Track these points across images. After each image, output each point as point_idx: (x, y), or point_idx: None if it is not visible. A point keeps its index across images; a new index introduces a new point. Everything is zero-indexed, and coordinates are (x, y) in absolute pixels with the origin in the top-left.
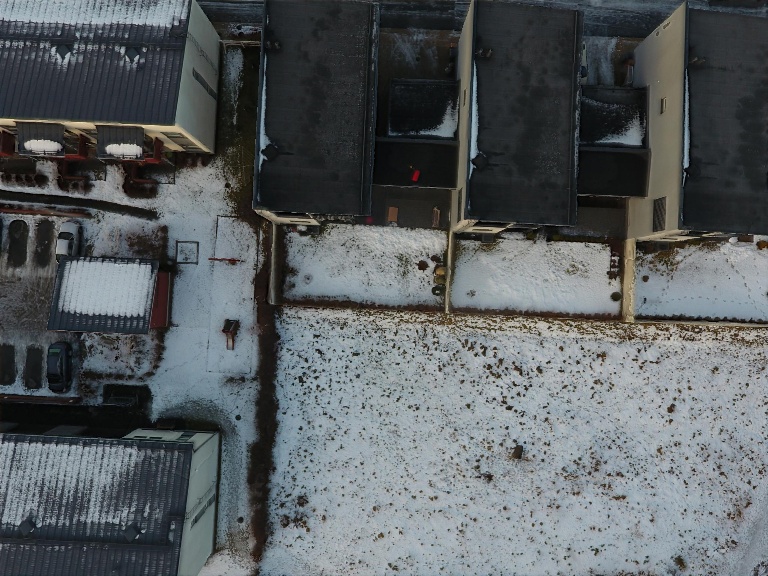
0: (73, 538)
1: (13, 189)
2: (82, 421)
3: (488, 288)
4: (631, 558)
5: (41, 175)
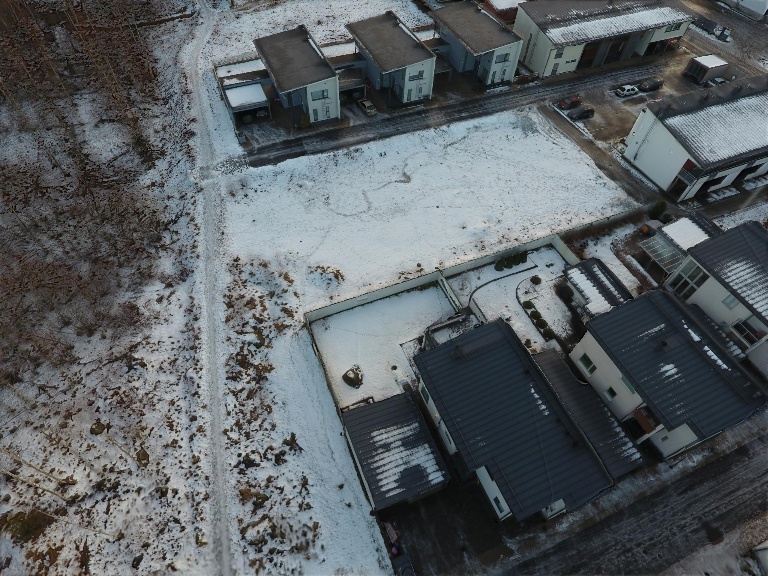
0: None
1: None
2: None
3: None
4: None
5: None
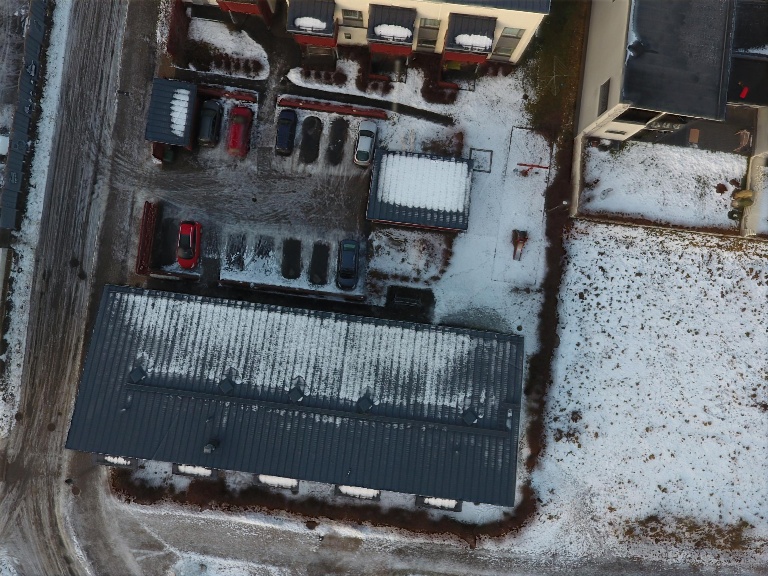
0: (412, 417)
1: (310, 86)
2: None
3: None
4: None
5: (341, 73)
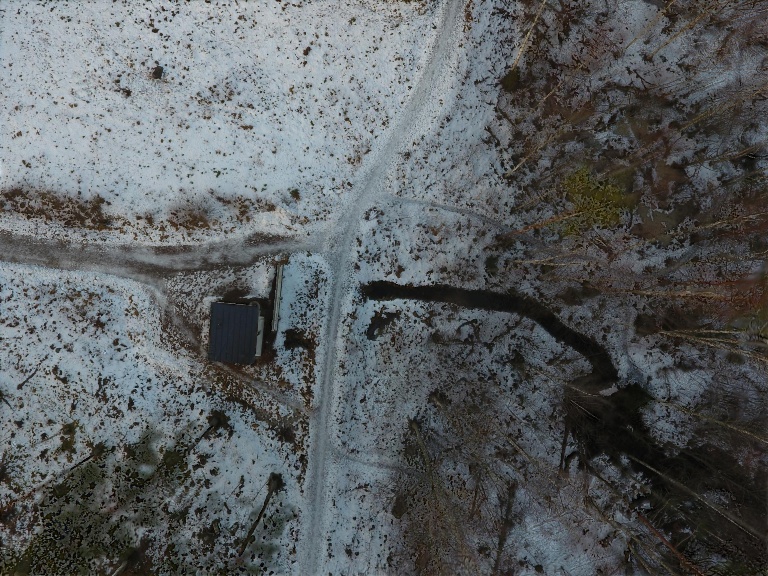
0: None
1: None
2: None
3: None
4: (250, 184)
5: None
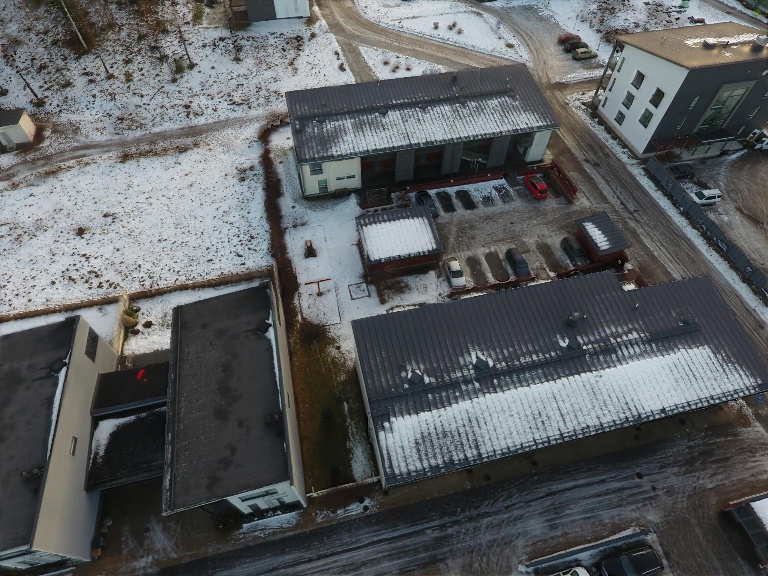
0: (354, 112)
1: None
2: (400, 184)
3: (88, 322)
4: (6, 197)
5: None
